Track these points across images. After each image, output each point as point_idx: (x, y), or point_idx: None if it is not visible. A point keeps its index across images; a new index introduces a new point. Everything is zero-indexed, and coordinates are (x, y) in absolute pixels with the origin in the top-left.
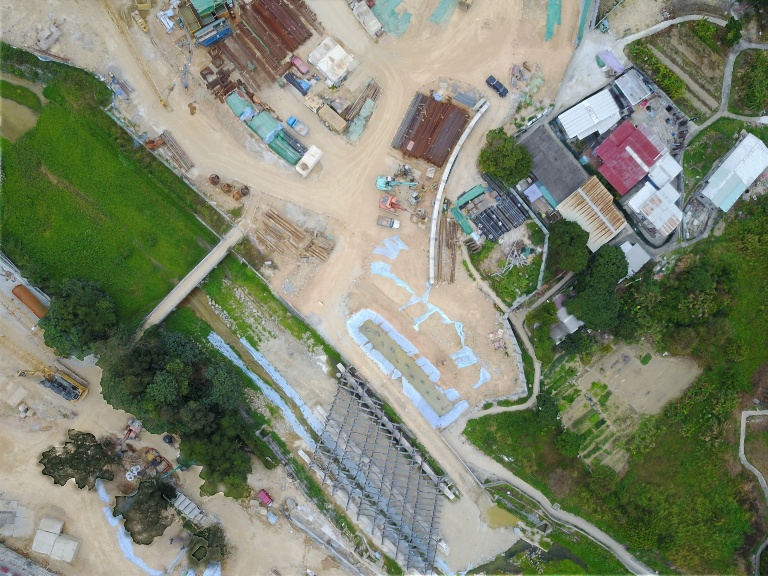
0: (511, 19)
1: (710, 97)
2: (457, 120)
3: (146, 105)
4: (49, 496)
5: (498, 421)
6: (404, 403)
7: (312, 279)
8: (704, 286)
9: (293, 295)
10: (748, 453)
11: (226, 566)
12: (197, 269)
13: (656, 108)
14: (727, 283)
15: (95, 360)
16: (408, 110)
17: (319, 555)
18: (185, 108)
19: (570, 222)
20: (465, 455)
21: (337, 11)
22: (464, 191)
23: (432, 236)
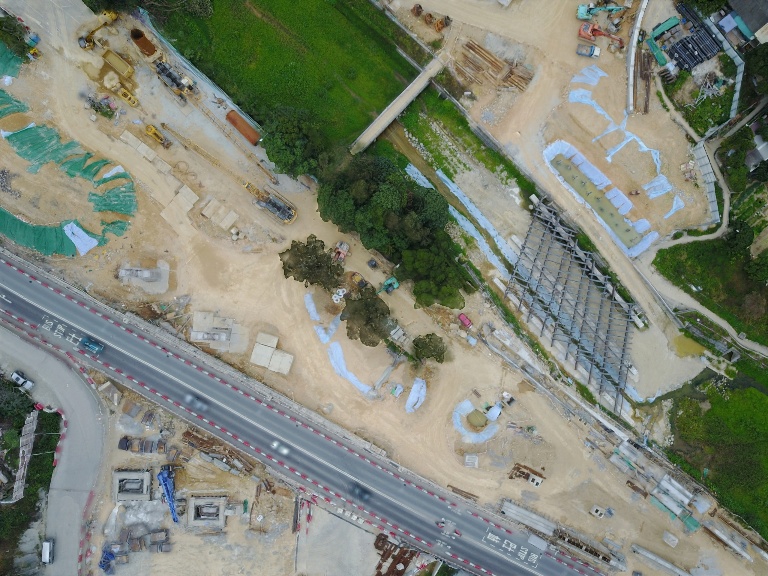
0: None
1: None
2: None
3: None
4: (262, 314)
5: (688, 250)
6: (598, 231)
7: (511, 109)
8: None
9: (492, 124)
10: None
11: (430, 385)
12: (399, 99)
13: None
14: None
15: (302, 187)
16: None
17: (515, 378)
18: None
19: None
20: (654, 284)
21: None
22: (659, 22)
23: (632, 63)
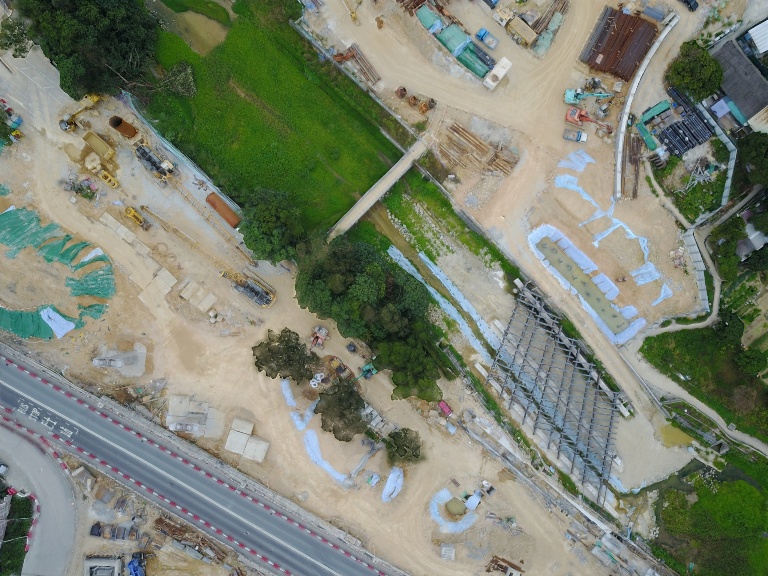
0: None
1: None
2: (646, 34)
3: (335, 19)
4: (238, 399)
5: (677, 339)
6: (583, 318)
7: (495, 193)
8: None
9: (476, 208)
10: None
11: (407, 473)
12: (381, 182)
13: None
14: None
15: (281, 269)
16: (596, 24)
17: (496, 467)
18: (372, 22)
19: (766, 134)
20: (641, 373)
21: None
22: (649, 106)
23: (619, 150)
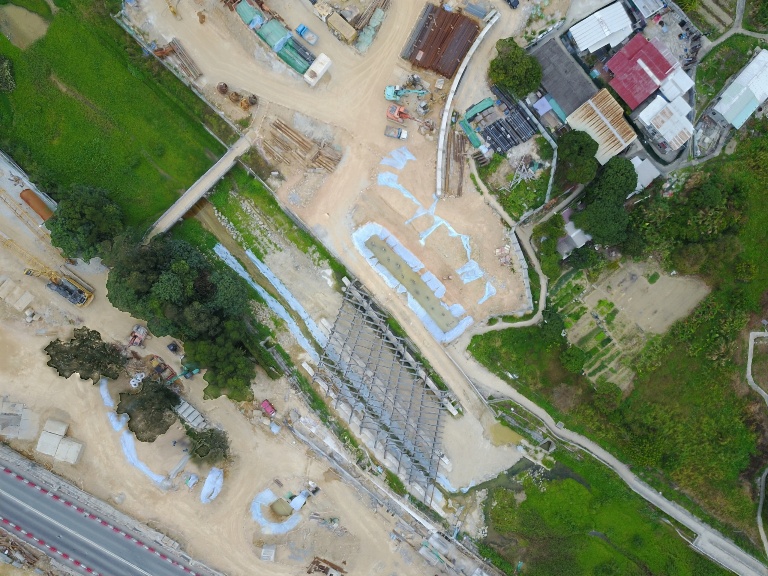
0: None
1: (724, 13)
2: (467, 31)
3: (155, 13)
4: (54, 400)
5: (503, 337)
6: (409, 317)
7: (319, 190)
8: (714, 201)
9: (299, 206)
10: (755, 375)
11: (228, 474)
12: (204, 178)
13: (669, 23)
14: (738, 200)
15: (101, 267)
16: (418, 20)
17: (321, 467)
18: (194, 16)
19: (579, 132)
20: (469, 371)
21: None
22: (473, 104)
23: (440, 147)
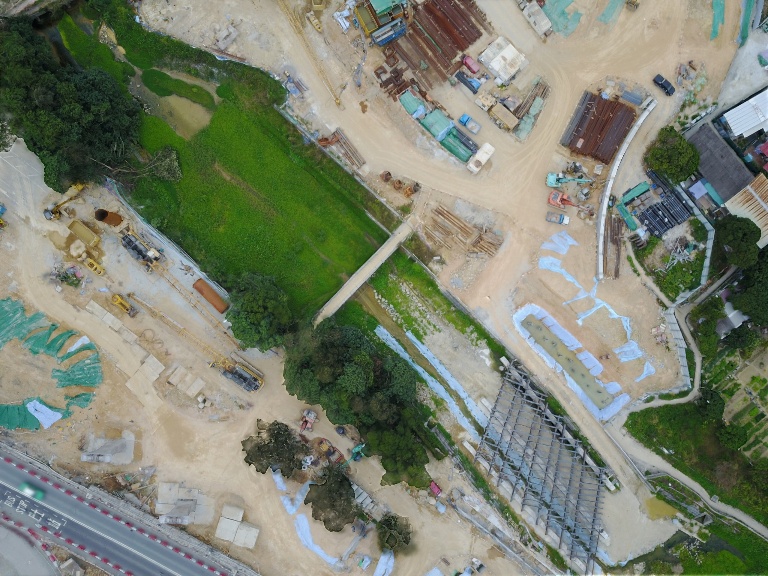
0: (676, 19)
1: None
2: (625, 118)
3: (319, 103)
4: (228, 485)
5: (660, 414)
6: (568, 396)
7: (480, 274)
8: None
9: (461, 290)
10: None
11: (398, 554)
12: (368, 264)
13: None
14: None
15: (269, 352)
16: (577, 108)
17: (485, 544)
18: (357, 106)
19: (743, 218)
20: (626, 447)
21: (506, 11)
22: (629, 188)
23: (601, 232)
